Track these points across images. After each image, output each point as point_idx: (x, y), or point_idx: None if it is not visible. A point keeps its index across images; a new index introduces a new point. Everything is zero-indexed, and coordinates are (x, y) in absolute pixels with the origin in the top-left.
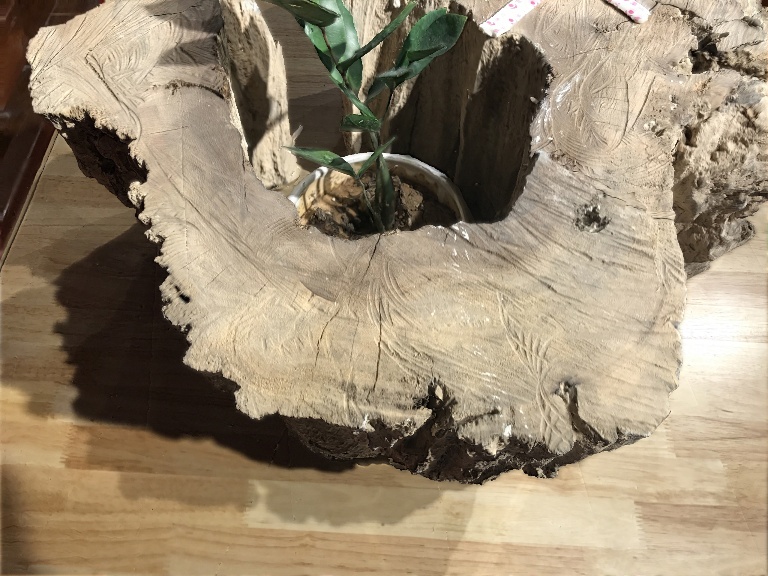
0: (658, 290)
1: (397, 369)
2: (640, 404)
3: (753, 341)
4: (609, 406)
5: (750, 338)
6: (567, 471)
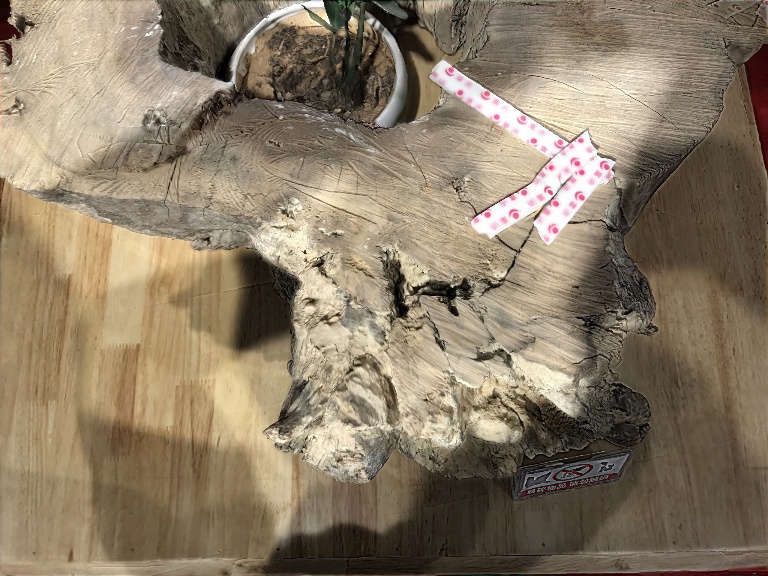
0: (86, 170)
1: (44, 1)
2: (0, 155)
3: (293, 485)
4: (2, 134)
5: (297, 482)
6: (166, 291)
